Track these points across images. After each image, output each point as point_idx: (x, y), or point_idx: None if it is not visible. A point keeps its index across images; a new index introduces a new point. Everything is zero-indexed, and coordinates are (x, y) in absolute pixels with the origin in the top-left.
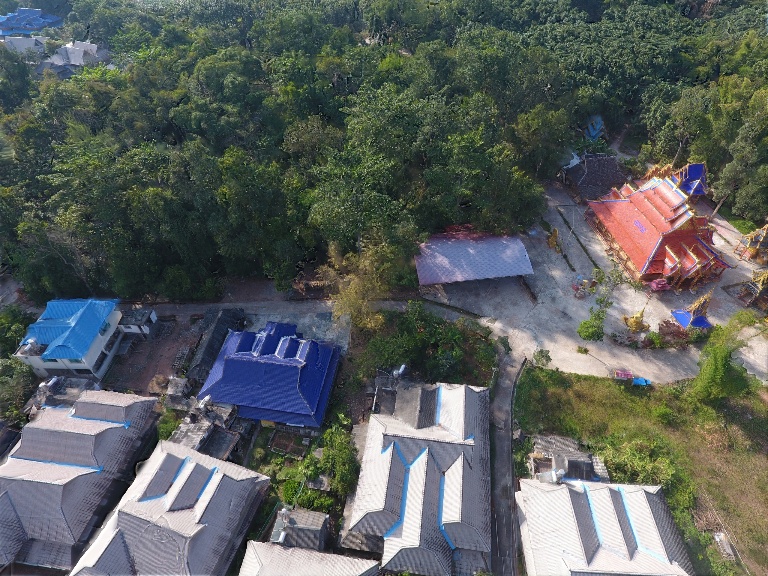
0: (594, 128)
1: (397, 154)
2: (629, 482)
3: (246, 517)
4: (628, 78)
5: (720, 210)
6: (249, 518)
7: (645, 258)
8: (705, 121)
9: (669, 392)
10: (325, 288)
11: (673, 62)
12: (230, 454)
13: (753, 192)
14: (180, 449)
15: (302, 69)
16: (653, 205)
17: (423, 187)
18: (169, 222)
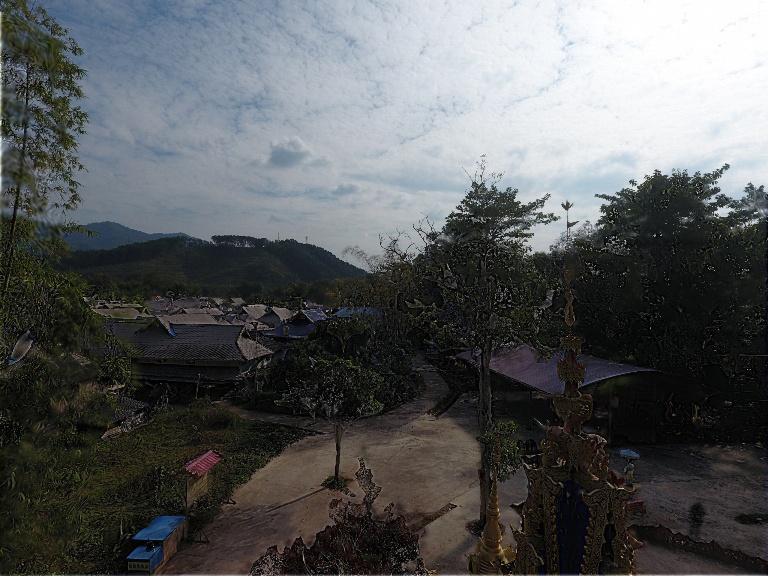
0: None
1: None
2: None
3: None
4: None
5: None
6: None
7: None
8: None
9: None
10: (449, 362)
11: None
12: None
13: None
14: None
15: None
16: None
17: None
18: None
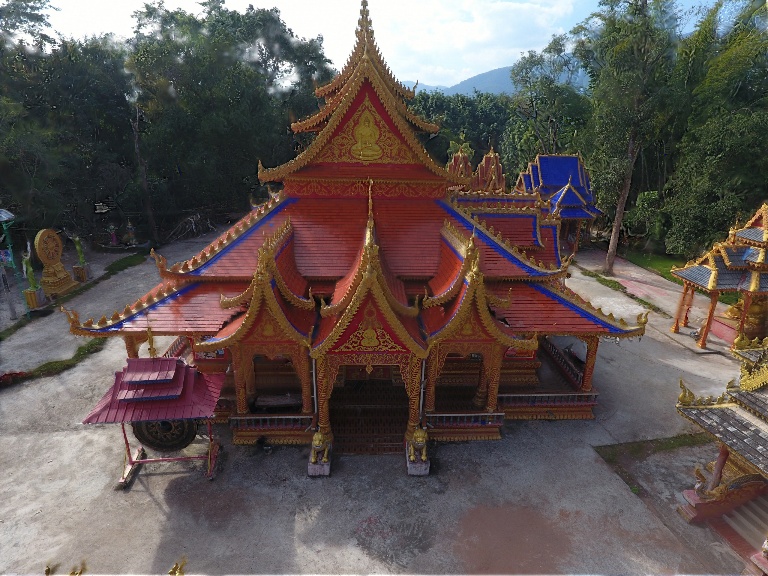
0: None
1: None
2: None
3: None
4: (482, 116)
5: (640, 258)
6: None
7: None
8: (578, 100)
9: None
10: None
11: None
12: None
13: (706, 183)
14: None
15: None
16: None
17: None
18: None
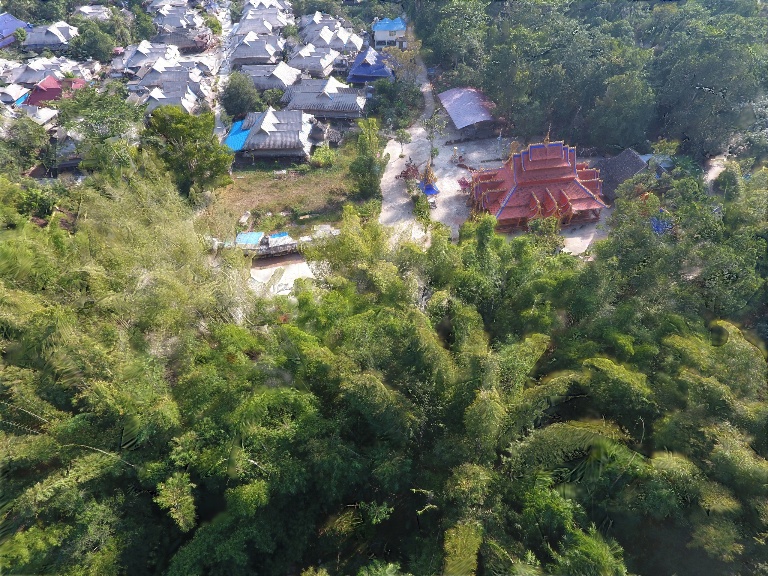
0: None
1: None
2: None
3: (311, 73)
4: None
5: None
6: (311, 74)
7: None
8: None
9: None
10: None
11: None
12: (339, 72)
13: None
14: (335, 55)
15: None
16: None
17: None
18: (435, 7)
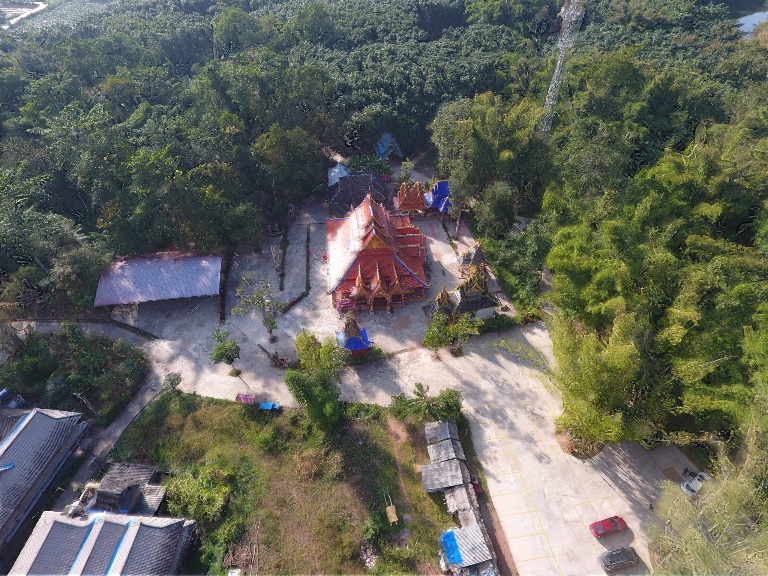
0: (383, 145)
1: (104, 174)
2: (183, 514)
3: None
4: (426, 96)
5: (473, 227)
6: None
7: (339, 277)
8: None
9: (287, 417)
10: None
11: (486, 79)
12: None
13: (488, 209)
14: None
15: (52, 90)
16: (357, 223)
17: (115, 207)
18: None
